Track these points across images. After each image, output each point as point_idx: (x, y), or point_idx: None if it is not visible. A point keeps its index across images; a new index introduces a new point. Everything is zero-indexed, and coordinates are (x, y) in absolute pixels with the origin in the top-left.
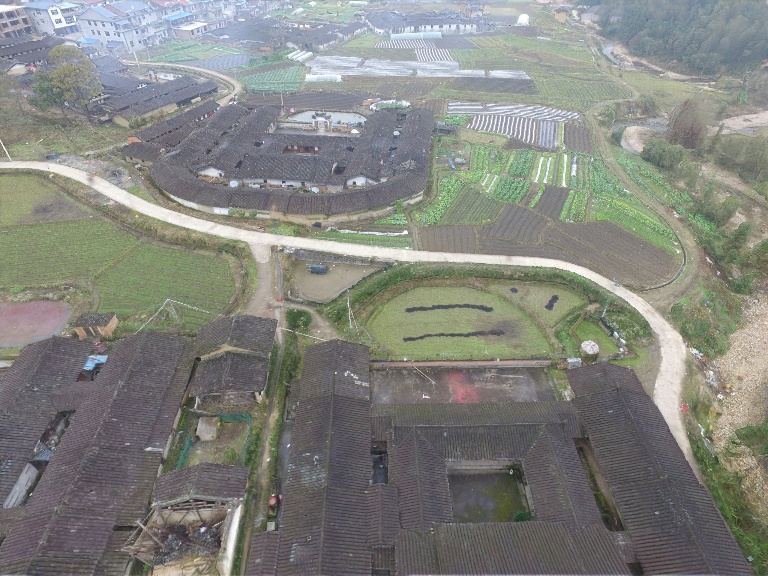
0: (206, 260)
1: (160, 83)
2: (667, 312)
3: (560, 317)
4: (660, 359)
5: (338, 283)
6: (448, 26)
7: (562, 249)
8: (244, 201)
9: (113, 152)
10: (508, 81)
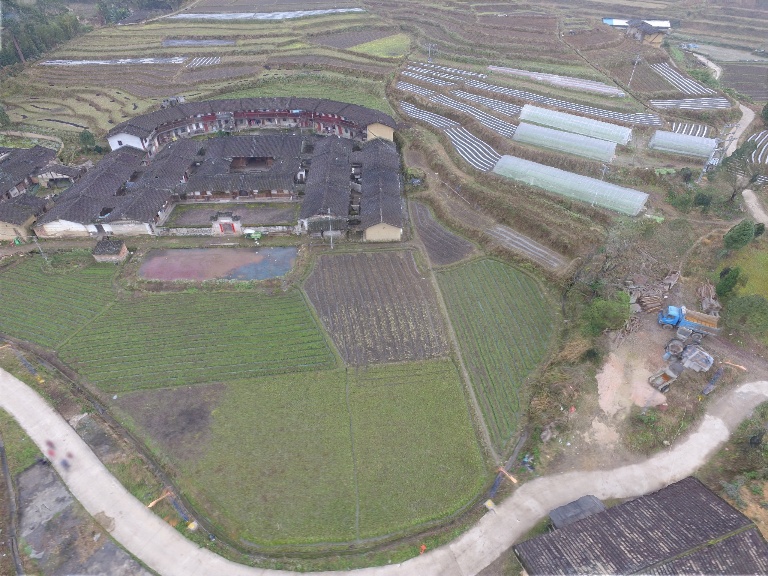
0: None
1: None
2: None
3: None
4: None
5: None
6: None
7: None
8: None
9: None
10: None
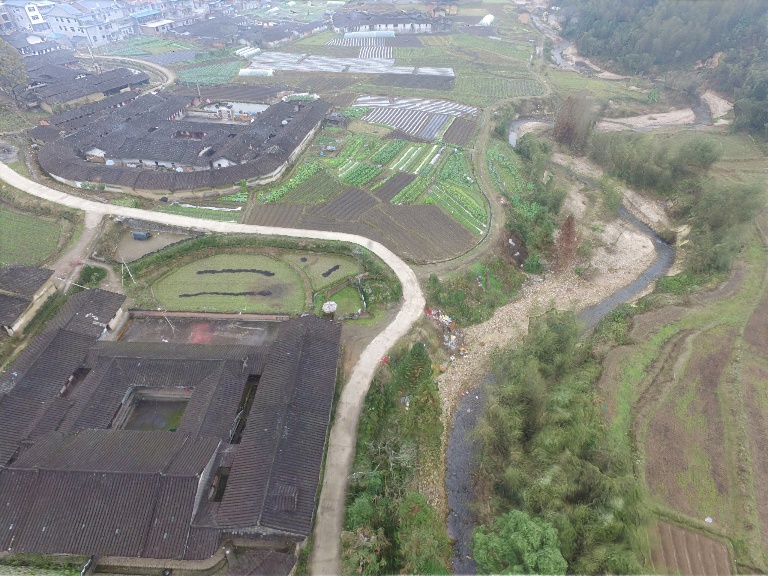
0: (45, 225)
1: (95, 74)
2: (427, 282)
3: (329, 283)
4: (392, 320)
5: (153, 248)
6: (403, 25)
7: (373, 227)
8: (100, 176)
9: (23, 134)
10: (430, 78)
